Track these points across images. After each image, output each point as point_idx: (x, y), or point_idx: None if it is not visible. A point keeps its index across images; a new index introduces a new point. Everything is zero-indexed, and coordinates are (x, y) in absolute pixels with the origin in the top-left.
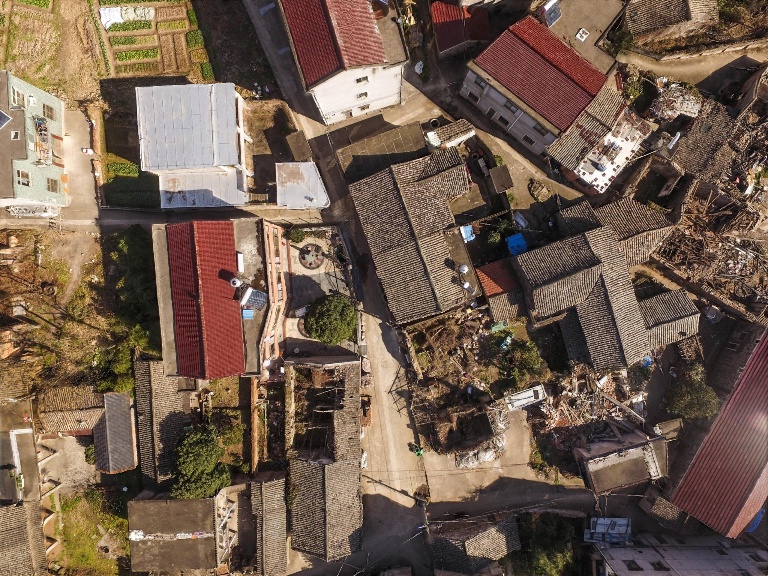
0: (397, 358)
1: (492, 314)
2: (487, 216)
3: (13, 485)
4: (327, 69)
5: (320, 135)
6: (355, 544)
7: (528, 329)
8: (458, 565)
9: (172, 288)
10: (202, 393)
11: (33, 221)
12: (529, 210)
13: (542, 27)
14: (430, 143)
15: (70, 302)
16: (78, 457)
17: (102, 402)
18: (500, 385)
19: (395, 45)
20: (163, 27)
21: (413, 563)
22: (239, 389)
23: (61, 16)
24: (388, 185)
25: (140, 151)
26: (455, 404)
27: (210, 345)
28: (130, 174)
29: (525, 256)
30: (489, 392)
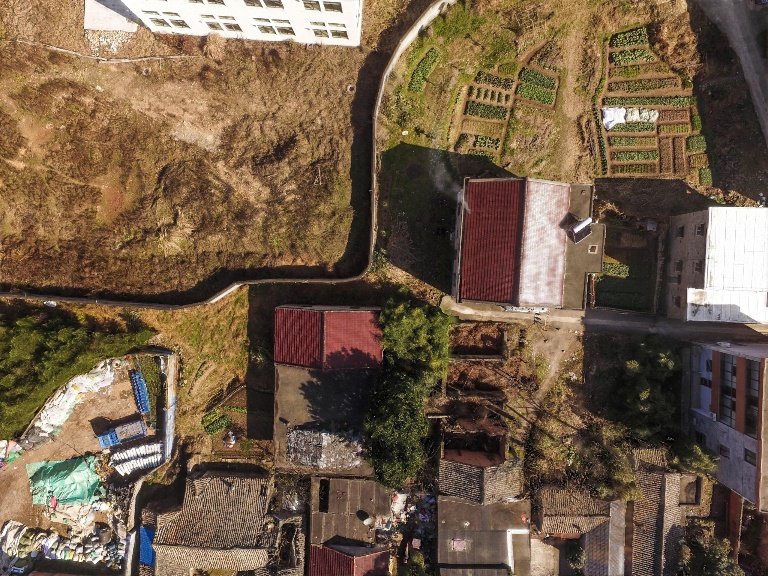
0: None
1: None
2: None
3: None
4: None
5: None
6: None
7: None
8: None
9: None
10: None
11: (519, 315)
12: None
13: None
14: None
15: (546, 398)
16: (538, 553)
17: (606, 510)
18: None
19: None
20: (665, 130)
21: None
22: (712, 500)
23: (562, 113)
24: None
25: (706, 270)
26: None
27: None
28: (619, 275)
29: None
30: None
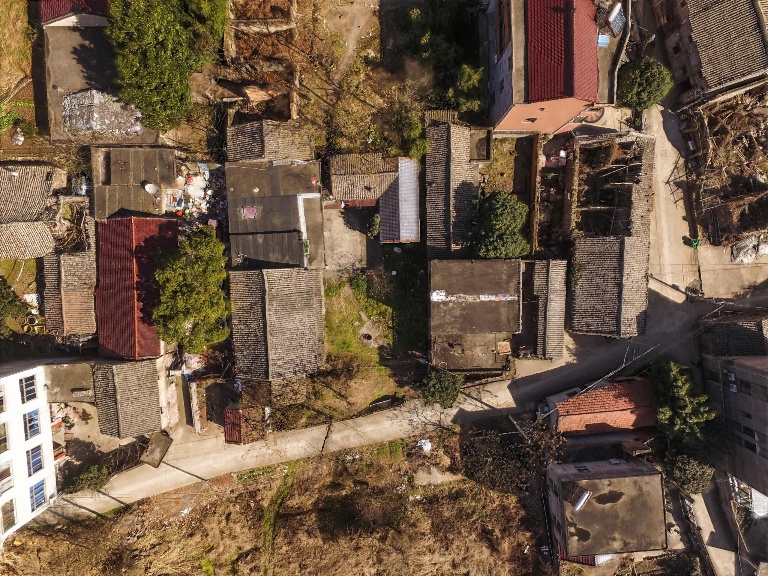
0: (677, 147)
1: None
2: None
3: (301, 249)
4: None
5: None
6: (640, 326)
7: None
8: (748, 348)
9: (528, 9)
10: (479, 174)
11: None
12: None
13: None
14: None
15: (344, 77)
16: (345, 240)
17: (395, 167)
18: None
19: None
20: None
21: (680, 360)
22: (514, 174)
23: None
24: None
25: None
26: (739, 193)
27: (577, 61)
28: None
29: None
30: None
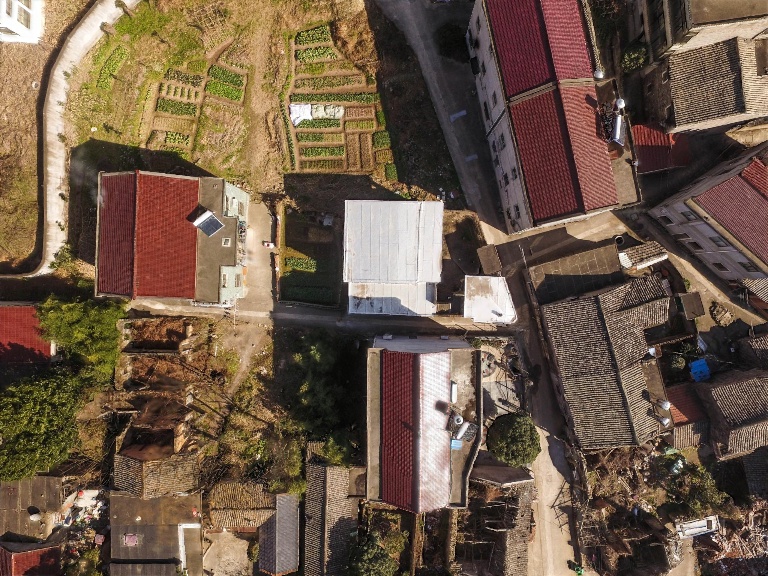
0: (563, 473)
1: (673, 441)
2: (668, 338)
3: None
4: (561, 209)
5: (501, 243)
6: None
7: (700, 453)
8: None
9: (383, 413)
10: None
11: (208, 310)
12: (709, 333)
13: (767, 171)
14: (621, 264)
15: (237, 392)
16: (232, 548)
17: (273, 503)
18: (668, 509)
19: (627, 186)
20: (351, 126)
21: None
22: None
23: (251, 109)
24: (591, 313)
25: (344, 263)
26: (622, 526)
27: (424, 478)
28: (307, 269)
29: (720, 390)
30: (656, 515)
